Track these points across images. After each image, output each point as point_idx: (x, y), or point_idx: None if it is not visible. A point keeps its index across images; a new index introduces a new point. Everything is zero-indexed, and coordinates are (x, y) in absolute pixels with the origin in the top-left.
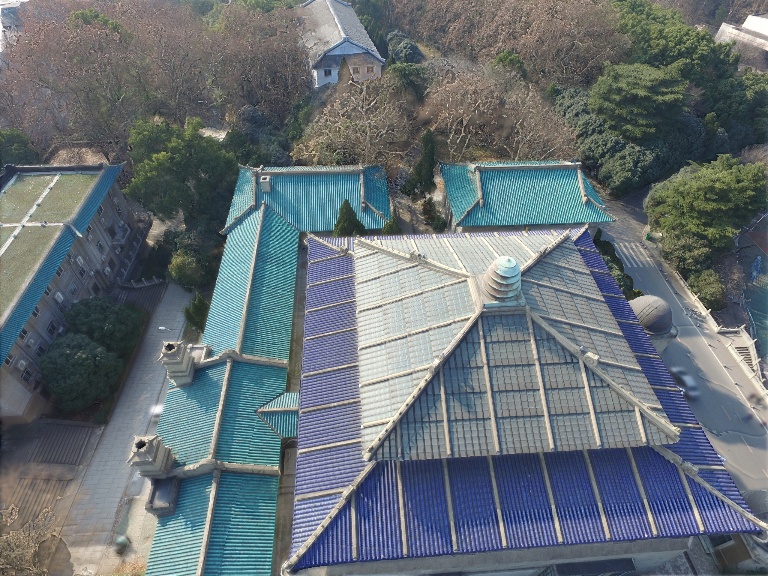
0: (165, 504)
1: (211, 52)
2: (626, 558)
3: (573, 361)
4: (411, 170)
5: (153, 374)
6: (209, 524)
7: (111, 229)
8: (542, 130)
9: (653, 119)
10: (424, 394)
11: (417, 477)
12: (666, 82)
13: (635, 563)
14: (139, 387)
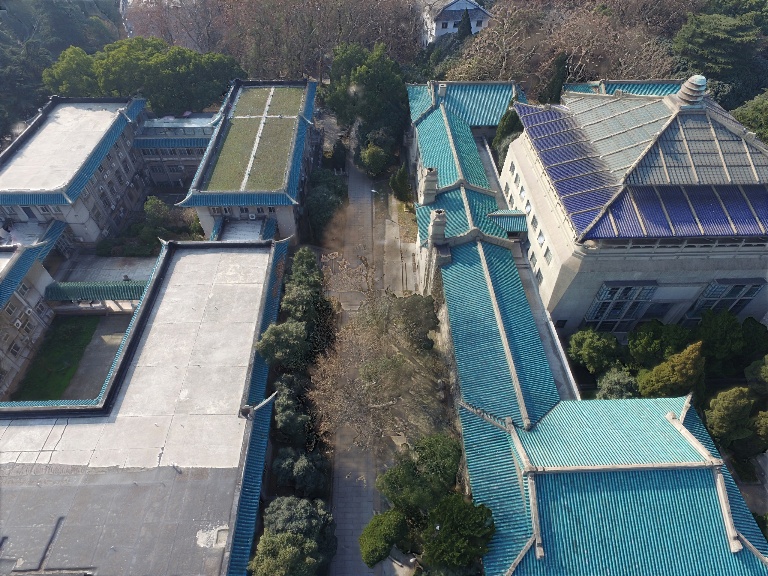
0: (448, 255)
1: (369, 1)
2: (761, 278)
3: (738, 139)
4: (545, 86)
5: (362, 228)
6: (485, 260)
7: (310, 131)
8: (635, 68)
9: (730, 58)
10: (649, 153)
11: (644, 203)
12: (742, 28)
13: (762, 291)
14: (356, 234)
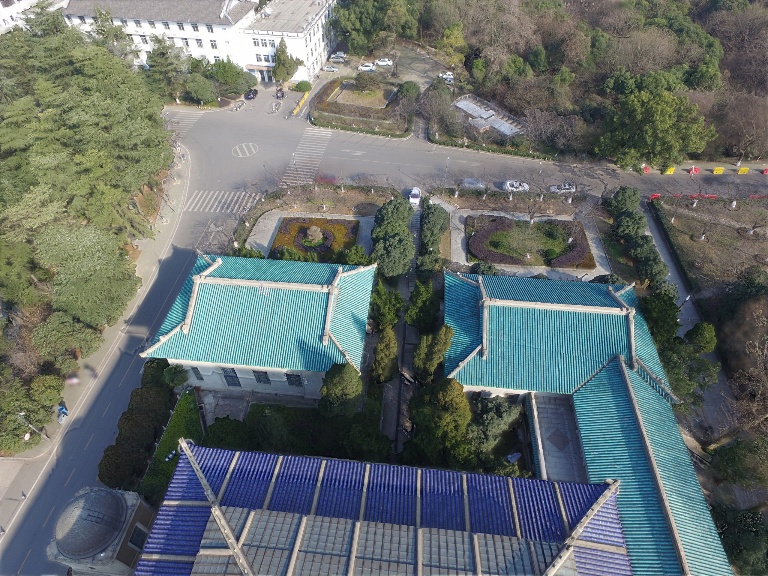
0: None
1: None
2: None
3: None
4: None
5: None
6: None
7: None
8: None
9: None
10: None
11: None
12: None
13: None
14: None
